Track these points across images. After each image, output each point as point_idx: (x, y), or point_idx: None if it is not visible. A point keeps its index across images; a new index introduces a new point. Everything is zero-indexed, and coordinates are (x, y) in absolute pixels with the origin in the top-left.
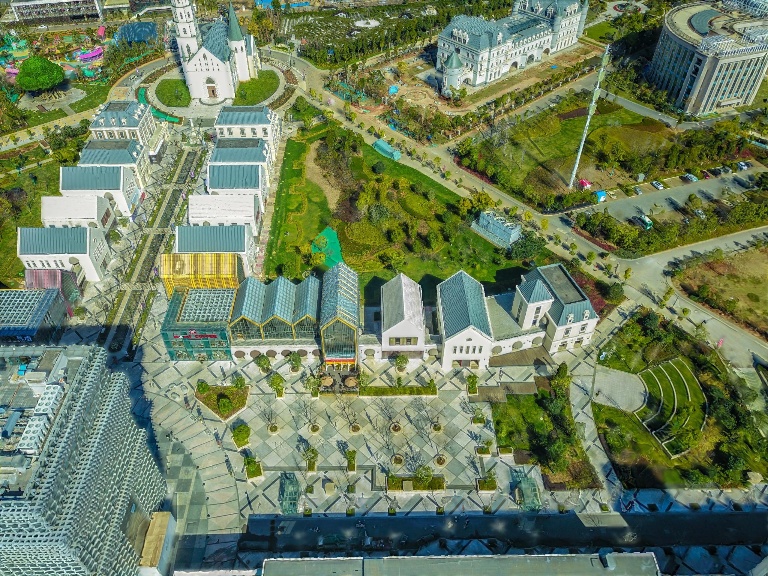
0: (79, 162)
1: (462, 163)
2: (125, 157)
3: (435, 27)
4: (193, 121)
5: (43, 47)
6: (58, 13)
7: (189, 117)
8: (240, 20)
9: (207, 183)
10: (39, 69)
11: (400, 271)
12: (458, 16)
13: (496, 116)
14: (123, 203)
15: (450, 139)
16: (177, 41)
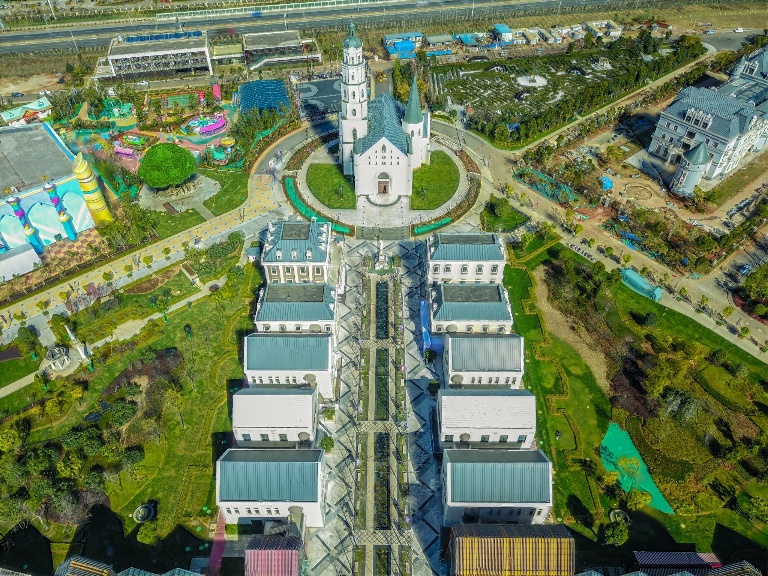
0: (257, 318)
1: (755, 311)
2: (320, 312)
3: (621, 88)
4: (368, 231)
5: (150, 112)
6: (162, 66)
7: (362, 225)
8: (379, 76)
9: (449, 363)
10: (170, 161)
11: (752, 515)
12: (687, 89)
13: (757, 227)
14: (327, 384)
15: (713, 265)
16: (342, 124)
